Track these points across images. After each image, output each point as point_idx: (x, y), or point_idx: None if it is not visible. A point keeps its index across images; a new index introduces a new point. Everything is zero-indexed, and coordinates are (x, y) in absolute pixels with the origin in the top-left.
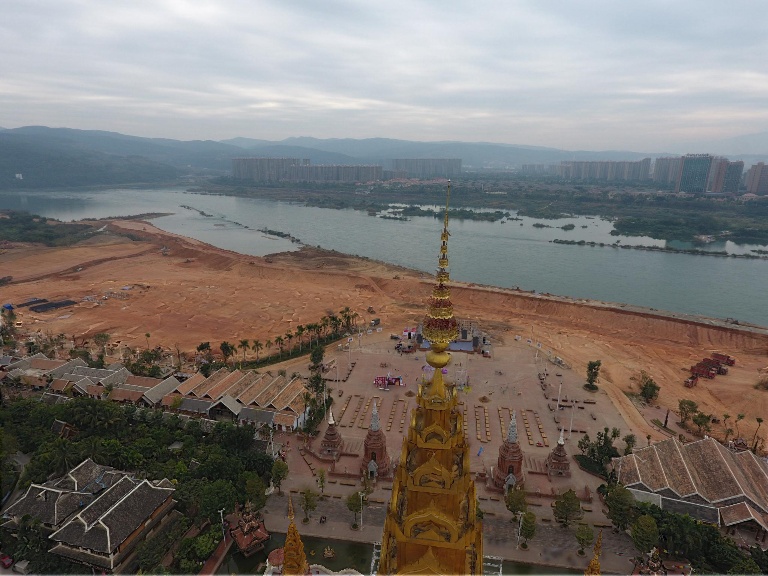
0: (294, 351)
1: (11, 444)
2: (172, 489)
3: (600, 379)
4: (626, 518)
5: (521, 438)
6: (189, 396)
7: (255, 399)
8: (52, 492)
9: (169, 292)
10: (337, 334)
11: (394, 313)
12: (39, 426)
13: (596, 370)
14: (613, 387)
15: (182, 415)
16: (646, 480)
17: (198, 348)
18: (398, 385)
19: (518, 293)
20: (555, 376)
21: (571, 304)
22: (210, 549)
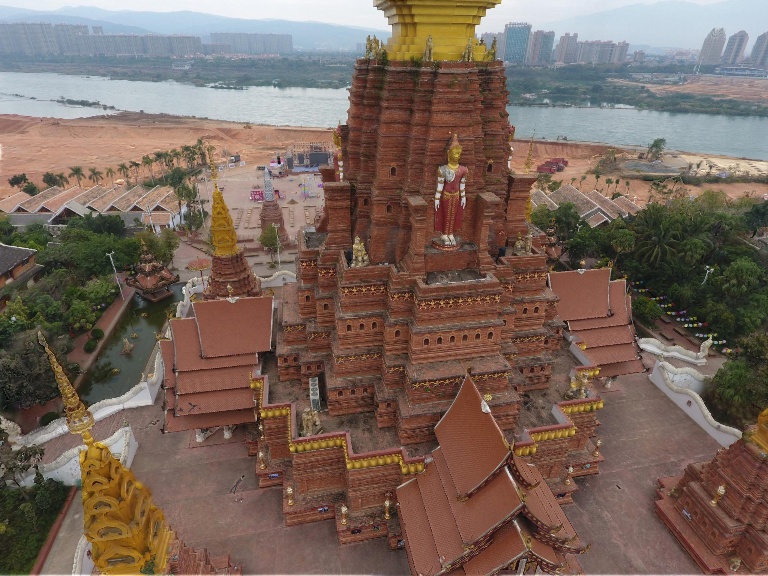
0: (145, 184)
1: None
2: (32, 249)
3: None
4: None
5: None
6: (17, 213)
7: (112, 203)
8: None
9: None
10: None
11: (254, 154)
12: None
13: None
14: None
15: (14, 225)
16: None
17: (10, 181)
18: (277, 198)
19: None
20: None
21: None
22: (106, 293)
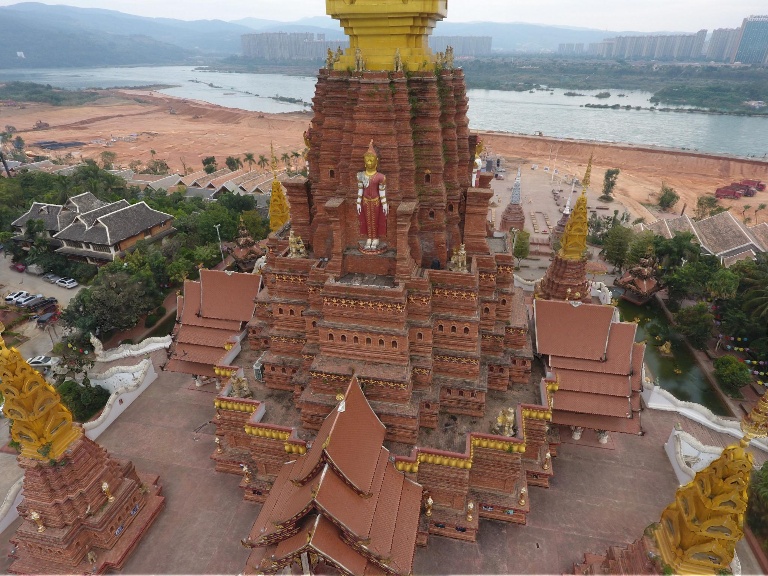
0: (301, 172)
1: (17, 193)
2: (170, 215)
3: (617, 194)
4: (624, 253)
5: (527, 229)
6: (193, 187)
7: (258, 185)
8: (53, 207)
9: (177, 137)
10: None
11: None
12: (44, 188)
13: (613, 179)
14: (630, 200)
15: (186, 196)
16: None
17: (203, 162)
18: None
19: (540, 137)
20: None
21: (596, 145)
22: (208, 257)
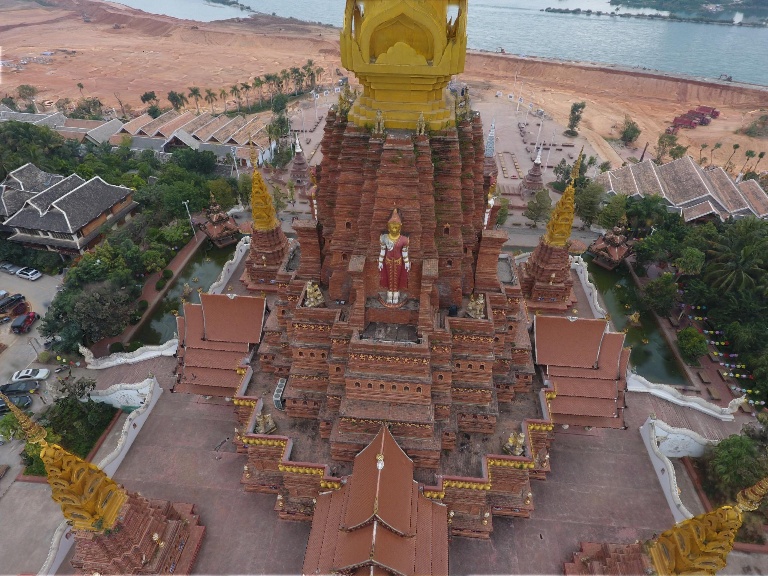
0: (254, 106)
1: None
2: (130, 189)
3: (581, 127)
4: (595, 211)
5: None
6: (139, 135)
7: (213, 134)
8: None
9: (100, 57)
10: (301, 92)
11: None
12: None
13: (579, 113)
14: (593, 134)
15: (134, 149)
16: (617, 190)
17: (142, 98)
18: None
19: (502, 55)
20: (535, 126)
21: (559, 65)
22: (180, 237)
